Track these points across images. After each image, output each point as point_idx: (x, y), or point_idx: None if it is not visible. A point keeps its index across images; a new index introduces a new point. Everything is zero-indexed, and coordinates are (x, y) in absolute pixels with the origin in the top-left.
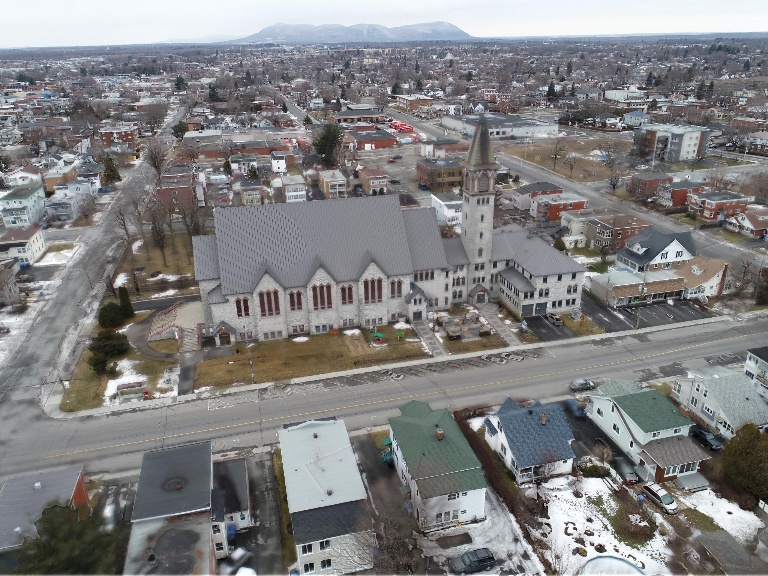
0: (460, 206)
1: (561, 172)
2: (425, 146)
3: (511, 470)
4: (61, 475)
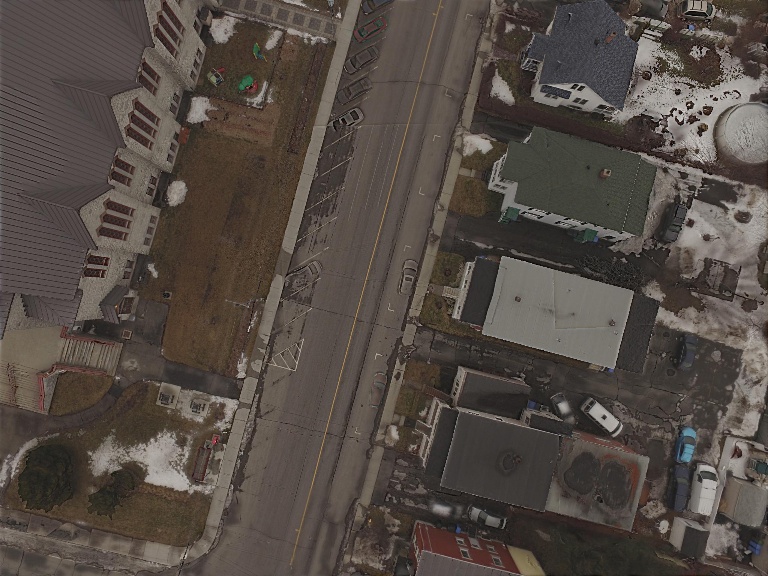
0: None
1: None
2: None
3: (596, 113)
4: (429, 573)
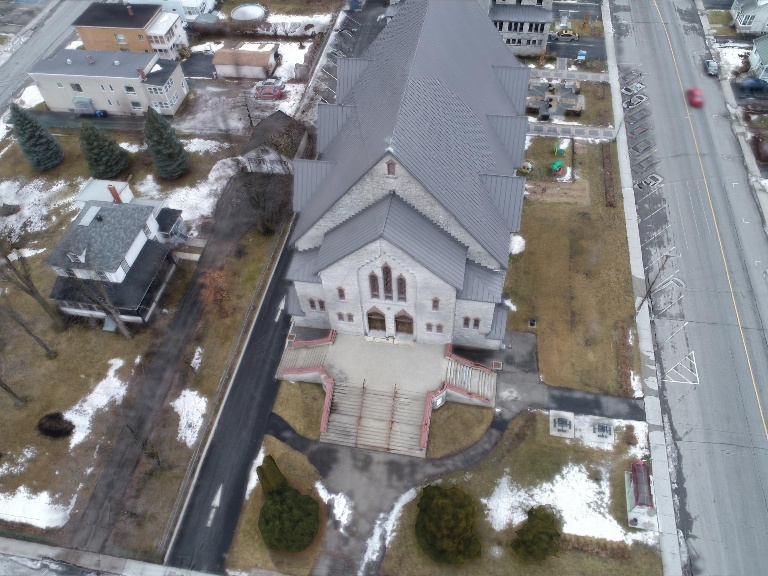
0: None
1: None
2: None
3: None
4: None
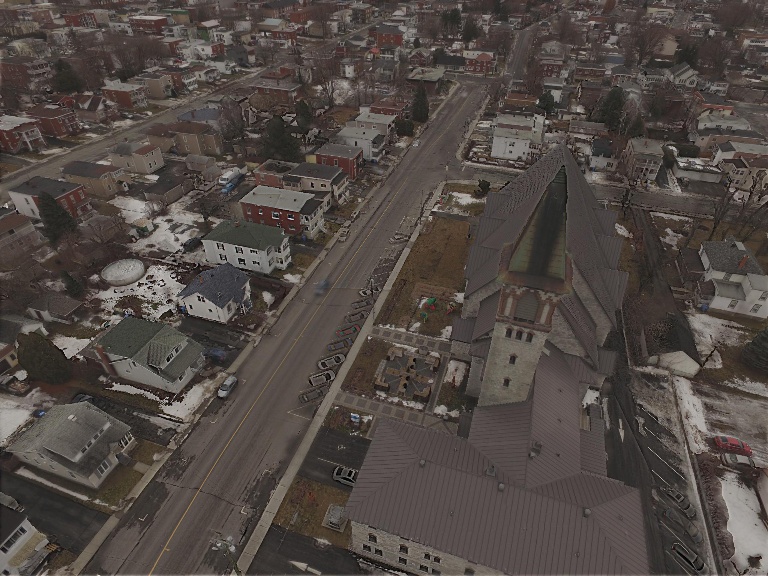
0: None
1: None
2: None
3: None
4: (352, 155)
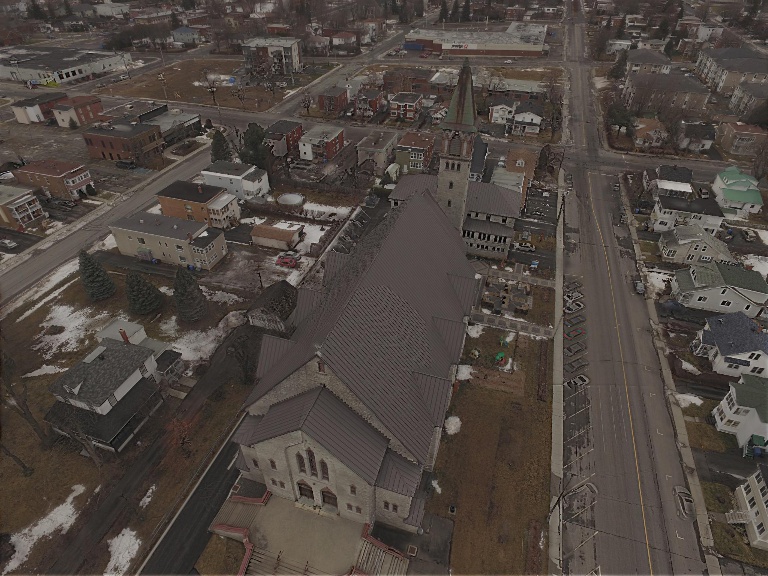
0: (259, 174)
1: (227, 105)
2: (24, 109)
3: None
4: None
